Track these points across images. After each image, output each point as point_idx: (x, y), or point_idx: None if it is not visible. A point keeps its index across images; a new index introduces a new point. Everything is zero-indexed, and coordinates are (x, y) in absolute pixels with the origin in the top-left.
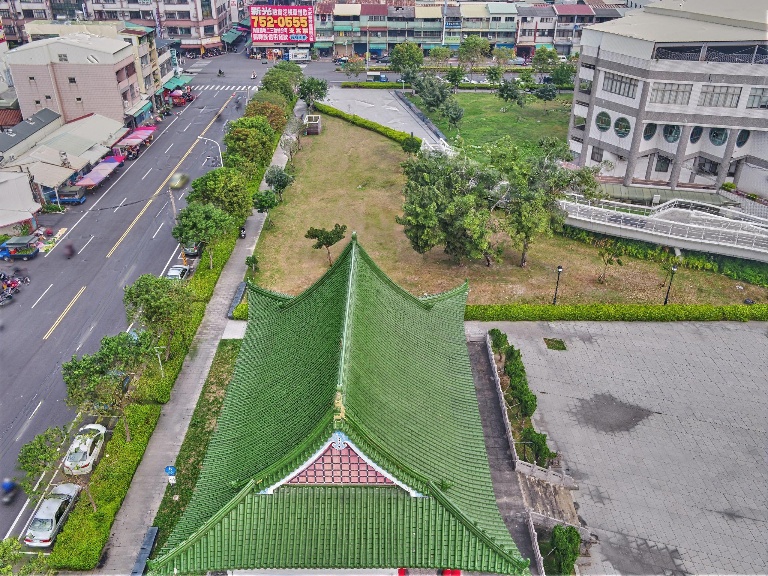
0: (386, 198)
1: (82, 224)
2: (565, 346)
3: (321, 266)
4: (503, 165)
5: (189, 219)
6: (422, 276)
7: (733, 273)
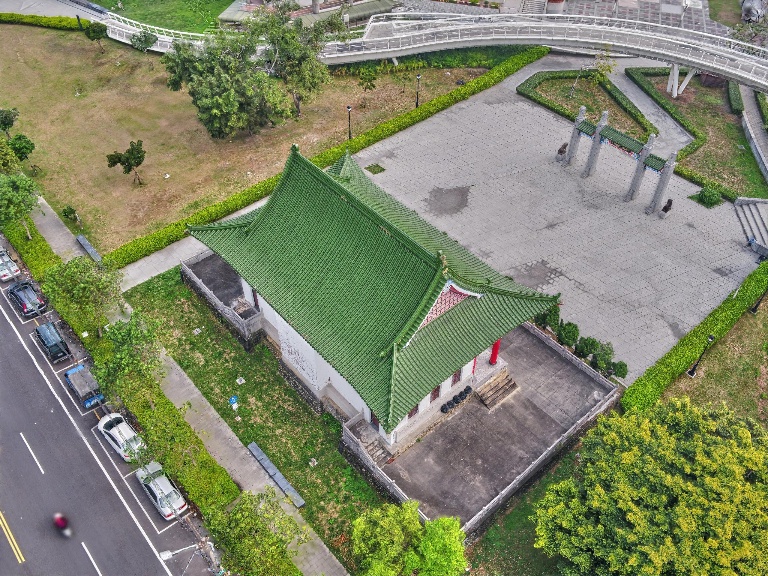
0: (118, 97)
1: None
2: (382, 167)
3: (132, 188)
4: (269, 34)
5: None
6: (230, 159)
7: (439, 64)
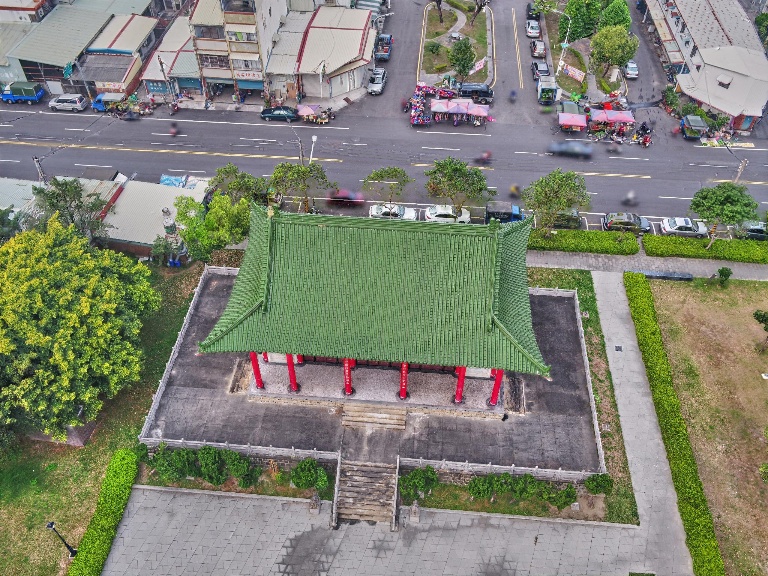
0: None
1: (767, 153)
2: None
3: (758, 342)
4: None
5: (710, 190)
6: None
7: None
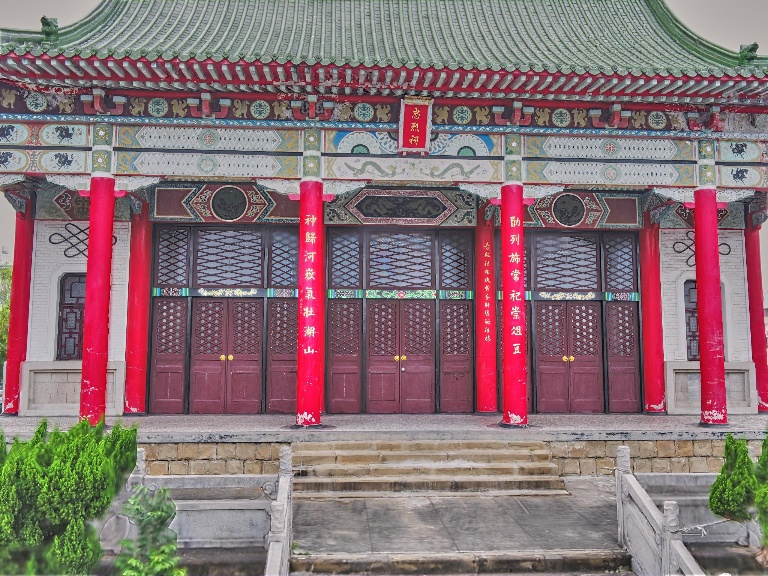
0: None
1: None
2: None
3: None
4: None
5: None
6: None
7: None
